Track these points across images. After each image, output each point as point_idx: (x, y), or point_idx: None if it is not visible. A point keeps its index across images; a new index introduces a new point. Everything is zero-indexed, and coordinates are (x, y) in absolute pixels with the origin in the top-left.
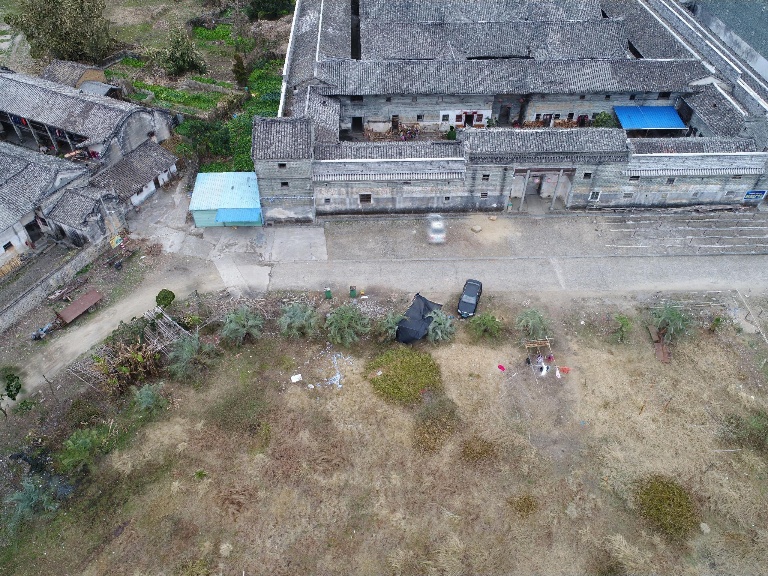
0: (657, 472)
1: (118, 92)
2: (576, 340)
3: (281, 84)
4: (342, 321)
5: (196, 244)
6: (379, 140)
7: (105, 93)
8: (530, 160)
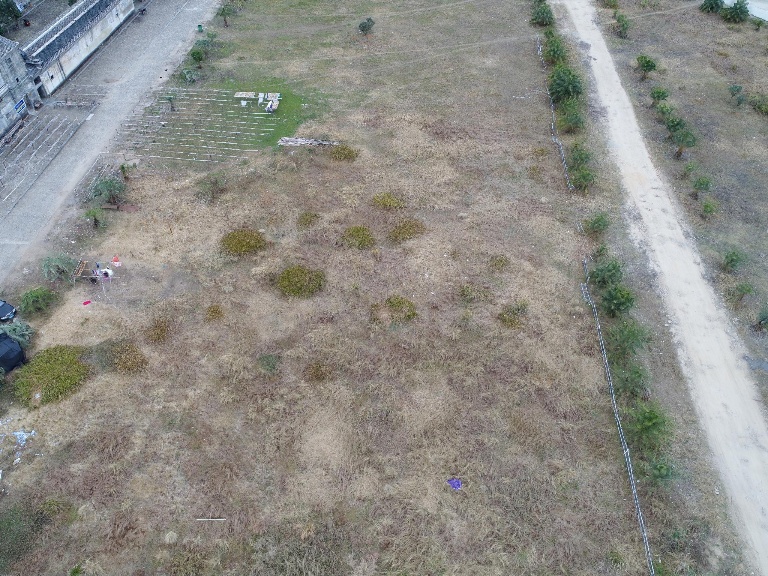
0: (219, 239)
1: None
2: (88, 250)
3: None
4: None
5: None
6: None
7: None
8: None
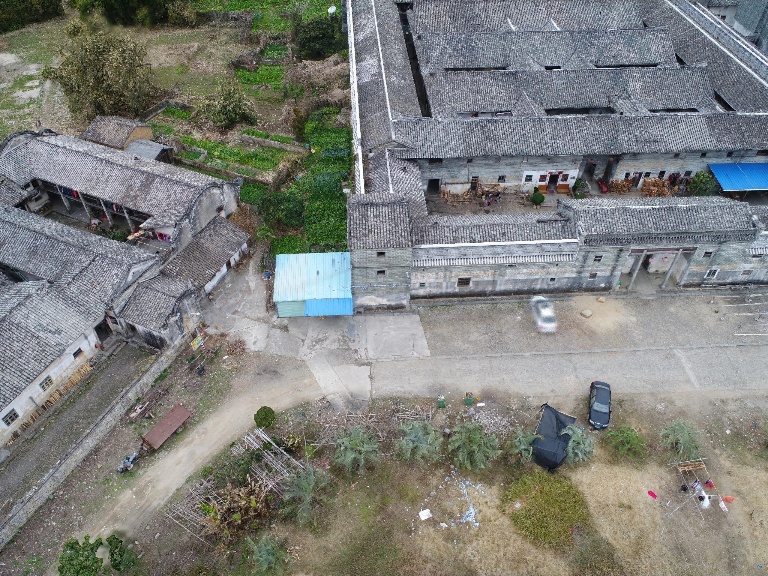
0: None
1: (169, 152)
2: (726, 455)
3: (341, 137)
4: (471, 444)
5: (282, 340)
6: (457, 203)
7: (157, 155)
8: (649, 241)
